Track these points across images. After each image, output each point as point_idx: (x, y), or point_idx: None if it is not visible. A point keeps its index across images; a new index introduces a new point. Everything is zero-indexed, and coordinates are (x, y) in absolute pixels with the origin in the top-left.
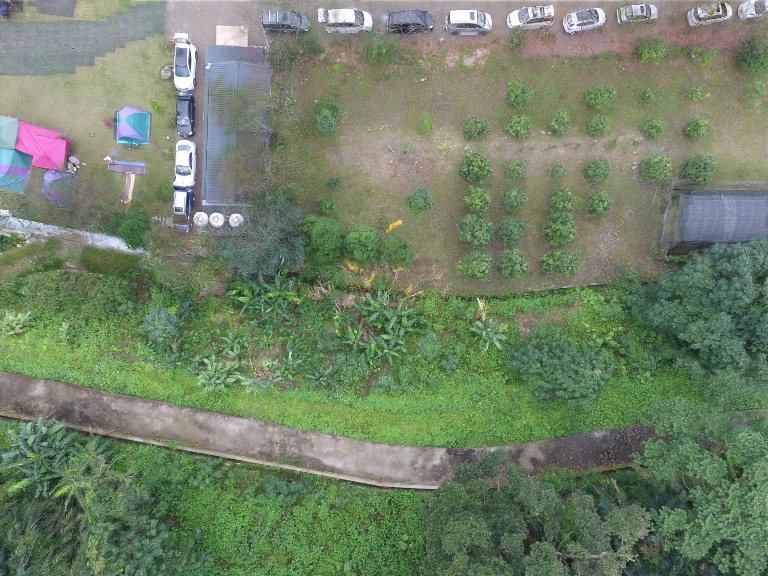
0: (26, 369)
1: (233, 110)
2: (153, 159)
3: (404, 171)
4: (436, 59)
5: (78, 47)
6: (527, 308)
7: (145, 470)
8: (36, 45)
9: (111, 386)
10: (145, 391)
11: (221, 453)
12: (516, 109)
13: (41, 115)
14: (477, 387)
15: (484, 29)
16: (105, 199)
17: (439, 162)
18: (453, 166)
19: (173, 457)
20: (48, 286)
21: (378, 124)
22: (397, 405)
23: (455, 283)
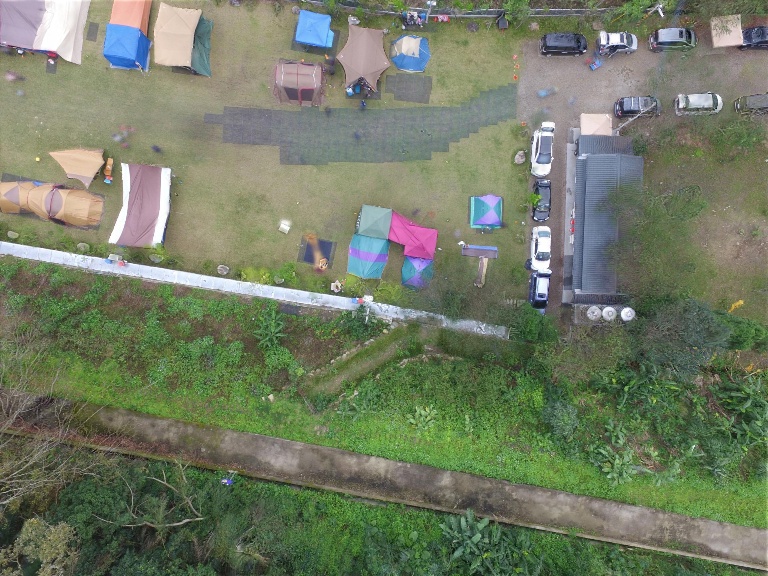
0: (434, 461)
1: (615, 203)
2: (505, 243)
3: (748, 252)
4: None
5: (434, 133)
6: None
7: (557, 559)
8: (394, 132)
9: (514, 477)
10: (543, 480)
11: (617, 540)
12: None
13: (399, 201)
14: None
15: None
16: (459, 283)
17: None
18: None
19: (576, 545)
20: (445, 379)
21: (722, 205)
22: None
23: None
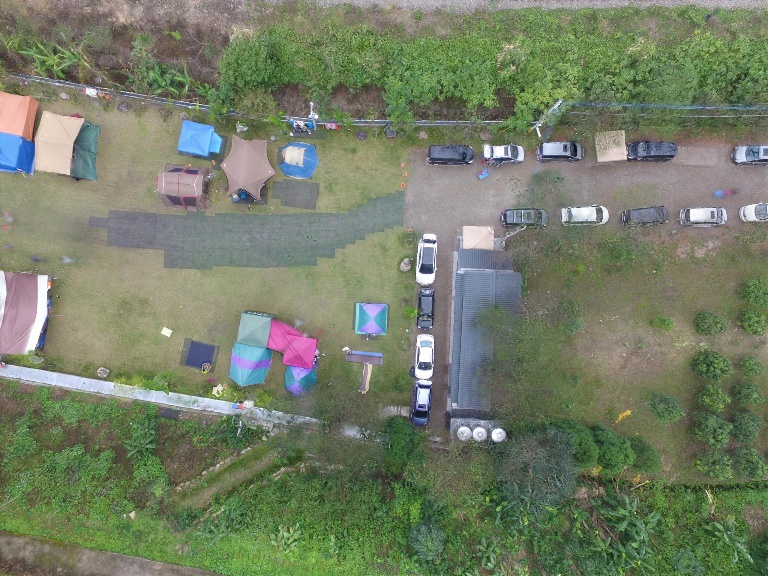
0: None
1: (490, 320)
2: (390, 350)
3: (635, 363)
4: (667, 250)
5: (320, 239)
6: (755, 501)
7: None
8: (279, 237)
9: None
10: None
11: None
12: None
13: (283, 306)
14: None
15: (720, 224)
16: (343, 388)
17: (670, 355)
18: (684, 359)
19: None
20: (313, 497)
21: (609, 315)
22: None
23: (682, 474)
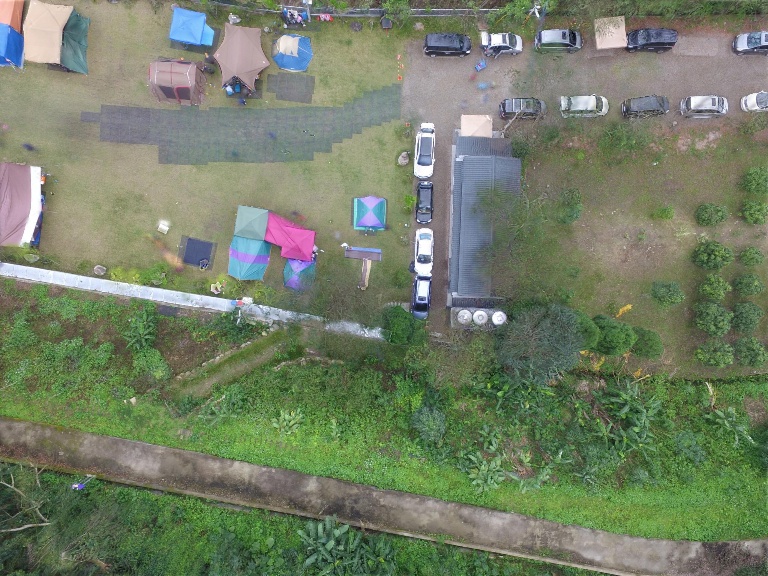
0: (299, 466)
1: (490, 205)
2: (389, 245)
3: (636, 256)
4: (668, 142)
5: (316, 134)
6: (755, 392)
7: (421, 567)
8: (275, 132)
9: (381, 482)
10: (412, 486)
11: (487, 547)
12: (748, 193)
13: (280, 202)
14: (729, 481)
15: (721, 113)
16: (342, 285)
17: (671, 247)
18: (685, 251)
19: (443, 552)
20: (314, 382)
21: (610, 209)
22: (654, 500)
23: (683, 367)
